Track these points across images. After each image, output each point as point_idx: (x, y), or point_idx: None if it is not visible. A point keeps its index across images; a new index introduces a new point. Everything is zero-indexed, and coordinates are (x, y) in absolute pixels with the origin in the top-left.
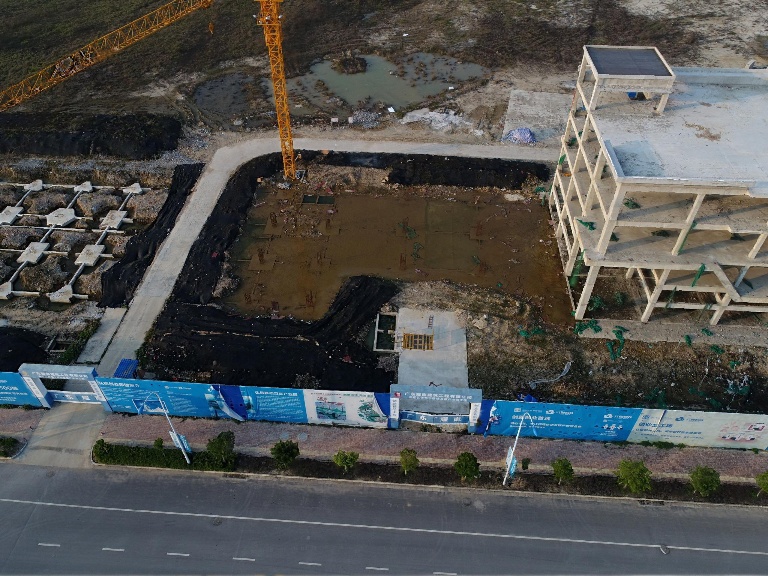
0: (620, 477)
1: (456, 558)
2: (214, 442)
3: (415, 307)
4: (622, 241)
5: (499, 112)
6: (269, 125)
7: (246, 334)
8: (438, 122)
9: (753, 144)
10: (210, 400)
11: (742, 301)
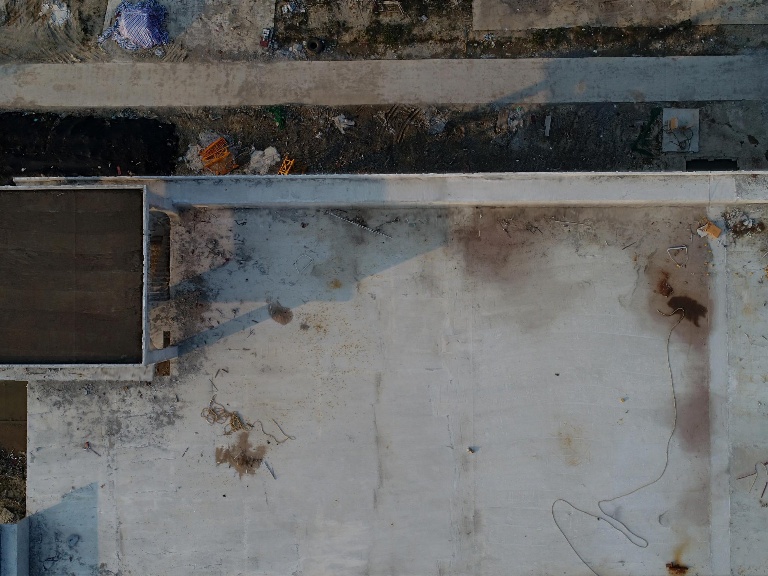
0: None
1: None
2: None
3: None
4: None
5: None
6: None
7: None
8: None
9: (316, 486)
10: None
11: None
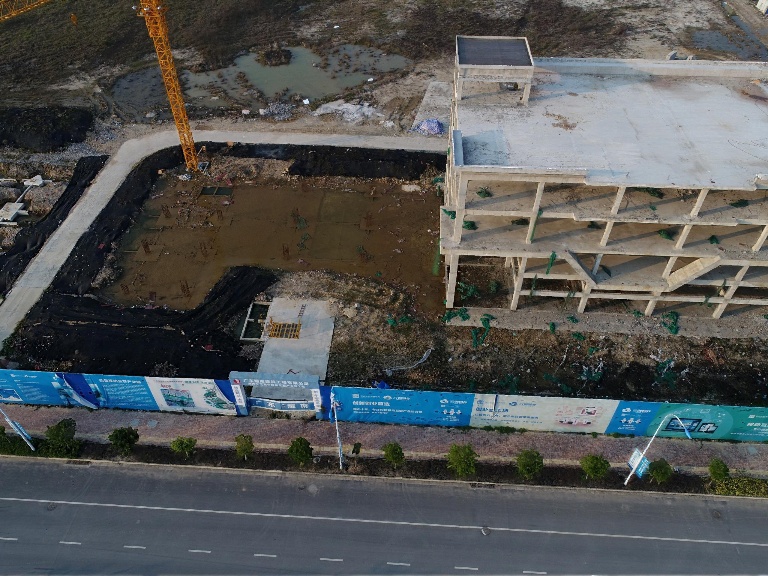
0: (450, 461)
1: (279, 540)
2: (52, 429)
3: (290, 296)
4: (480, 230)
5: (413, 103)
6: None
7: (113, 324)
8: (350, 114)
9: (605, 133)
10: (59, 388)
11: (599, 288)
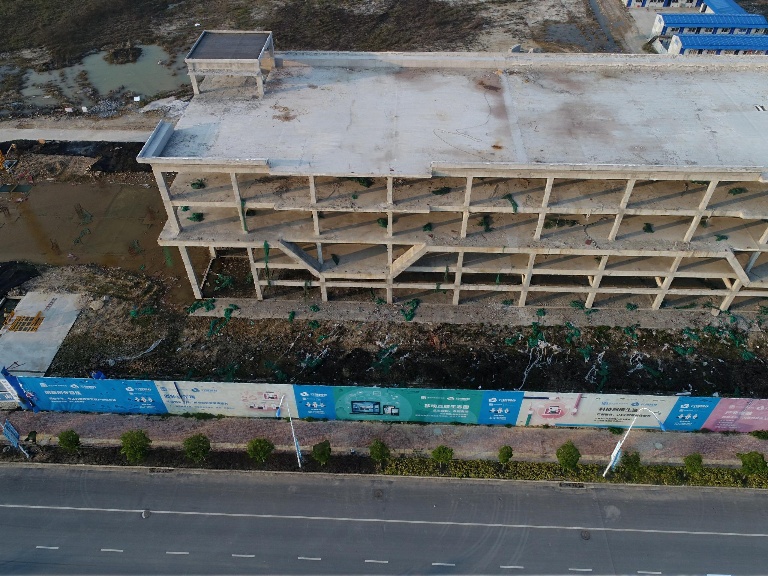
0: None
1: None
2: None
3: (44, 290)
4: (205, 221)
5: None
6: (6, 116)
7: None
8: (176, 110)
9: (319, 124)
10: None
11: (324, 277)
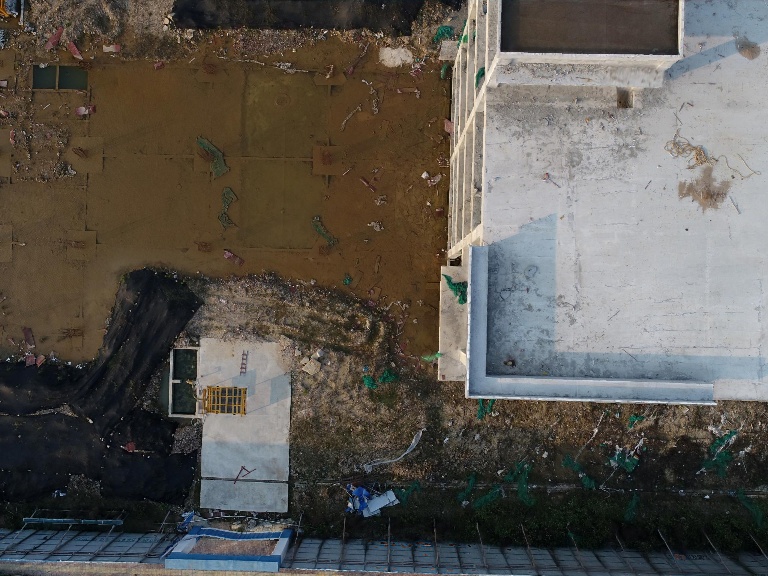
0: None
1: None
2: None
3: (223, 336)
4: None
5: None
6: None
7: None
8: None
9: None
10: None
11: None
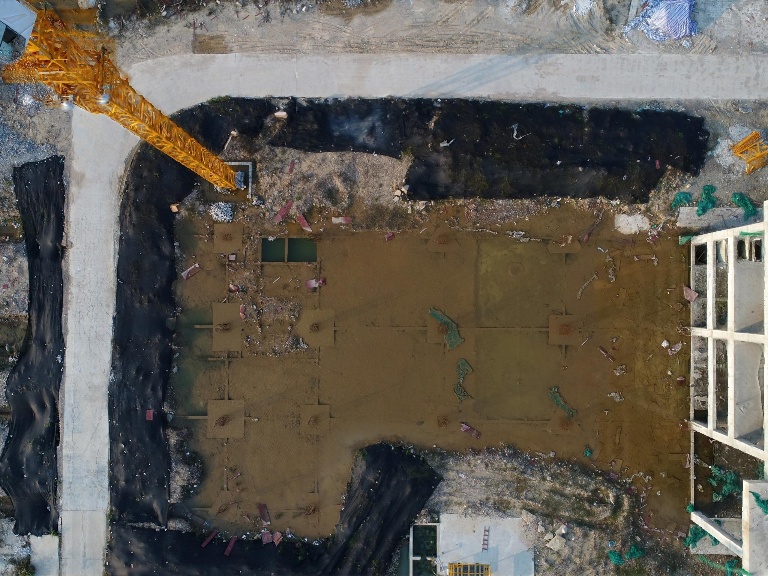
0: None
1: None
2: None
3: (463, 512)
4: None
5: None
6: (152, 8)
7: None
8: None
9: None
10: None
11: None
